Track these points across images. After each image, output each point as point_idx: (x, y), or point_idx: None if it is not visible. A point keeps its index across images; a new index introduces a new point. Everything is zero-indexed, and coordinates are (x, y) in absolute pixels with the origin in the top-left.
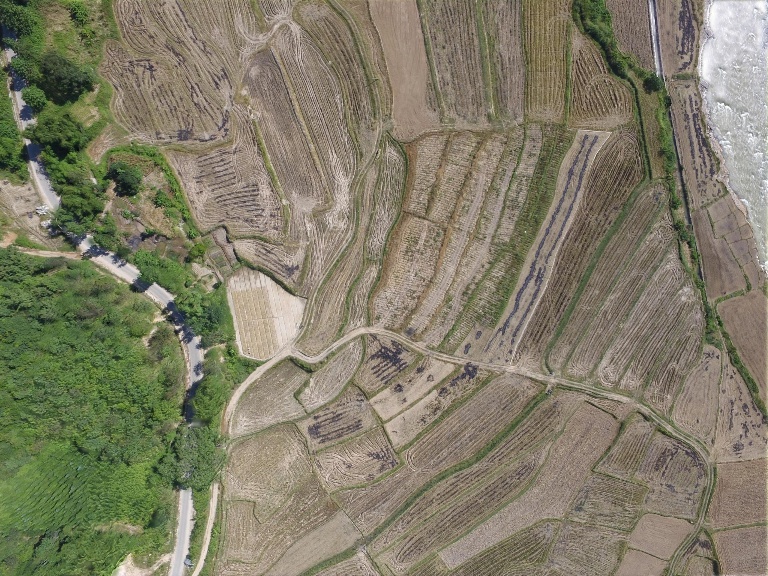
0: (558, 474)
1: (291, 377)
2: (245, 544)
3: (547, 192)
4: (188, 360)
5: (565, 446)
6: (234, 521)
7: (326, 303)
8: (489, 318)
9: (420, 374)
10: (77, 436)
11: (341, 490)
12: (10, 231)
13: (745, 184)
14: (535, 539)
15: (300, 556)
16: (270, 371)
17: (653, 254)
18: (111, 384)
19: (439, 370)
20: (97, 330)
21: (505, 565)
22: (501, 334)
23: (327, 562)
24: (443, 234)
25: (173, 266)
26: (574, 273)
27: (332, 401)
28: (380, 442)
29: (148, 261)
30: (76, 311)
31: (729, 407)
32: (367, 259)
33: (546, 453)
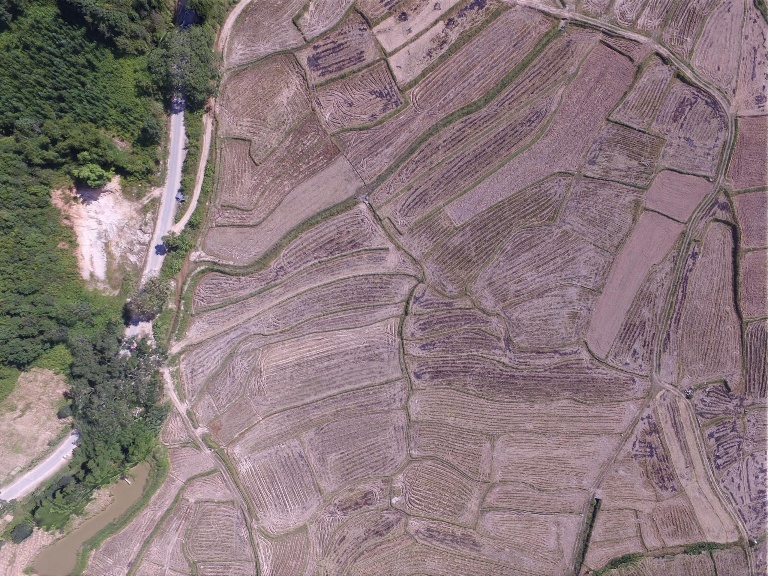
0: (571, 123)
1: (289, 0)
2: (240, 187)
3: None
4: None
5: (579, 92)
6: (229, 162)
7: None
8: None
9: (426, 2)
10: None
11: (342, 132)
12: None
13: None
14: (546, 195)
15: (298, 204)
16: None
17: None
18: None
19: None
20: None
21: (514, 223)
22: None
23: (327, 211)
24: None
25: None
26: None
27: (333, 28)
28: (383, 79)
29: None
30: None
31: (752, 55)
32: None
33: (558, 98)
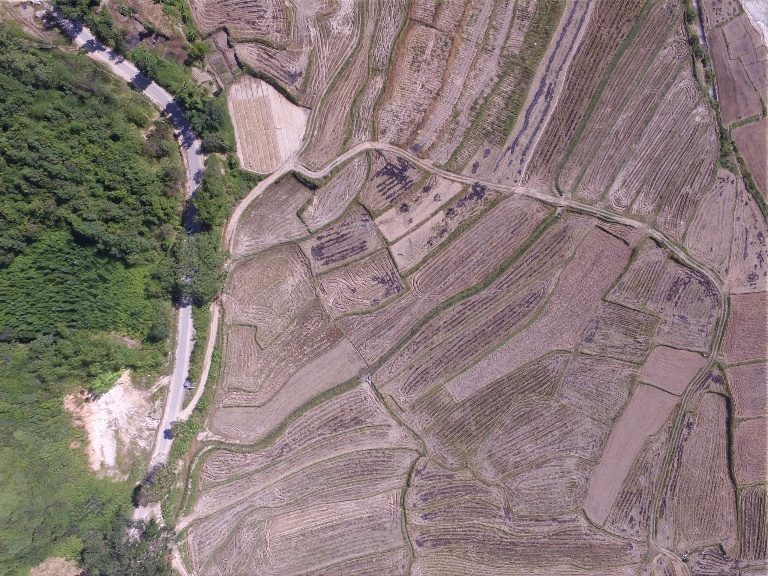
0: (568, 303)
1: (294, 194)
2: (246, 371)
3: (558, 2)
4: (188, 167)
5: (575, 273)
6: (235, 347)
7: (330, 114)
8: (498, 135)
9: (427, 193)
10: (73, 216)
11: (345, 316)
12: (3, 21)
13: (761, 6)
14: (544, 371)
15: (303, 385)
16: (272, 187)
17: (667, 71)
18: (108, 166)
19: (446, 189)
20: (93, 104)
21: (513, 398)
22: (510, 153)
23: (331, 392)
24: (451, 44)
25: (172, 66)
26: (585, 89)
27: (336, 220)
28: (385, 266)
29: (146, 57)
30: (71, 81)
31: (744, 235)
32: (372, 69)
33: (556, 280)
